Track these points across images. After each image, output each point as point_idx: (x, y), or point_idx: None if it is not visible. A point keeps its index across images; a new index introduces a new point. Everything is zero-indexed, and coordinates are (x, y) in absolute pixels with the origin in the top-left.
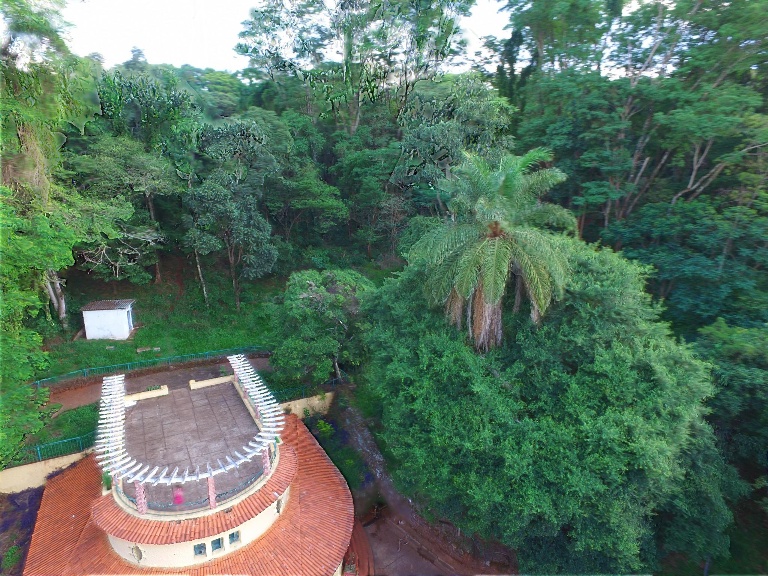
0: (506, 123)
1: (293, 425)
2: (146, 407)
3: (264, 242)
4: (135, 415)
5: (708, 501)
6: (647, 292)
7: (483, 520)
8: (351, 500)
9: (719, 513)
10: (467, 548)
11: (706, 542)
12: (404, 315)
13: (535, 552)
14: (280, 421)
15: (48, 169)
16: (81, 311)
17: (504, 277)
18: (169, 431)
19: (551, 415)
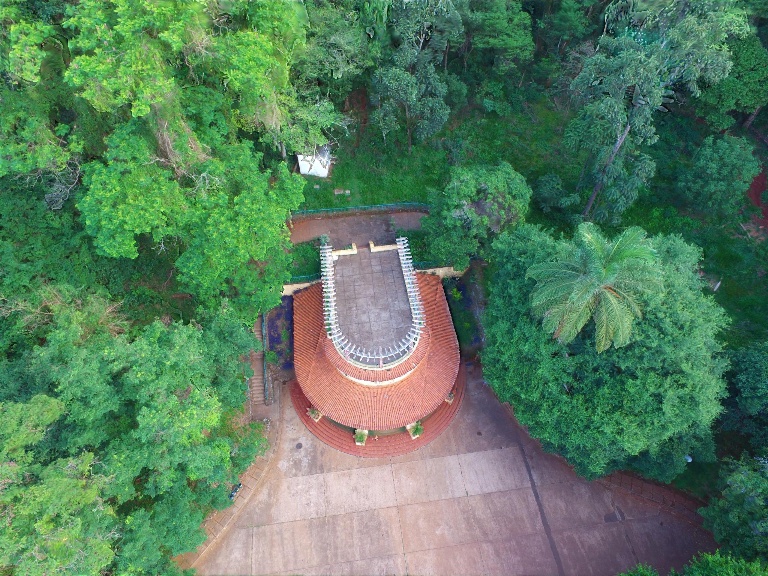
0: (731, 49)
1: (435, 288)
2: (344, 264)
3: (438, 108)
4: (338, 271)
5: (672, 459)
6: (718, 334)
7: None
8: (458, 363)
9: (674, 467)
10: None
11: (658, 473)
12: (515, 295)
13: None
14: (427, 284)
15: None
16: None
17: (578, 331)
18: (358, 293)
19: (585, 394)
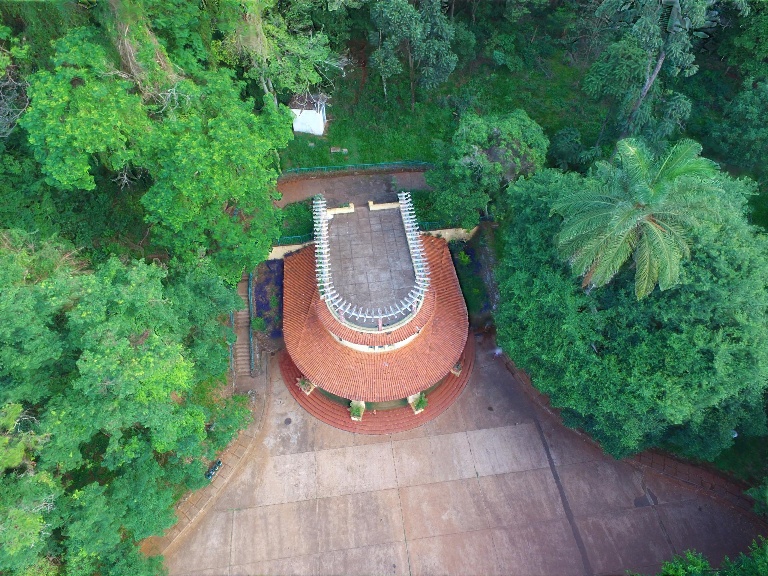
0: None
1: (440, 251)
2: (340, 223)
3: (444, 53)
4: (333, 230)
5: (717, 432)
6: None
7: None
8: (467, 329)
9: (720, 441)
10: None
11: (699, 449)
12: (536, 241)
13: None
14: (431, 246)
15: (262, 11)
16: None
17: (615, 271)
18: (355, 253)
19: (618, 353)
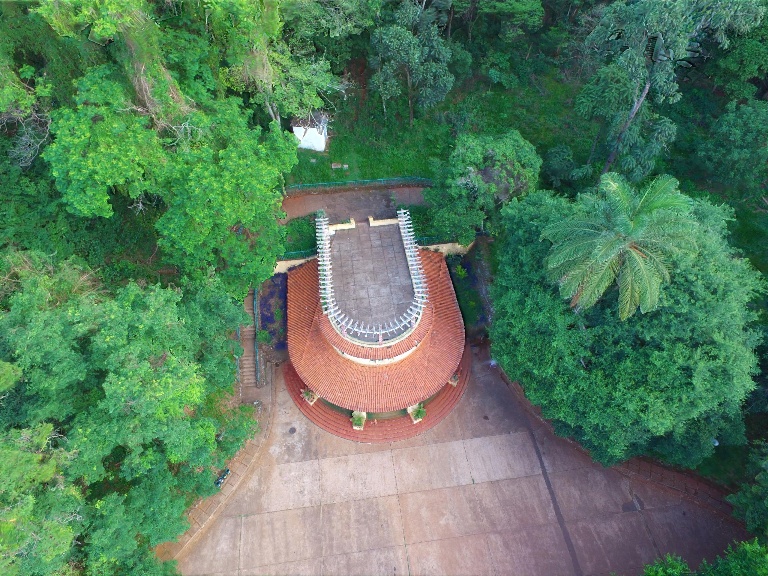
0: None
1: (438, 265)
2: (341, 239)
3: (442, 75)
4: (335, 246)
5: (698, 442)
6: (753, 301)
7: None
8: None
9: (701, 450)
10: None
11: (682, 457)
12: (527, 262)
13: None
14: (429, 261)
15: (267, 40)
16: (291, 126)
17: (599, 295)
18: (356, 268)
19: (605, 369)
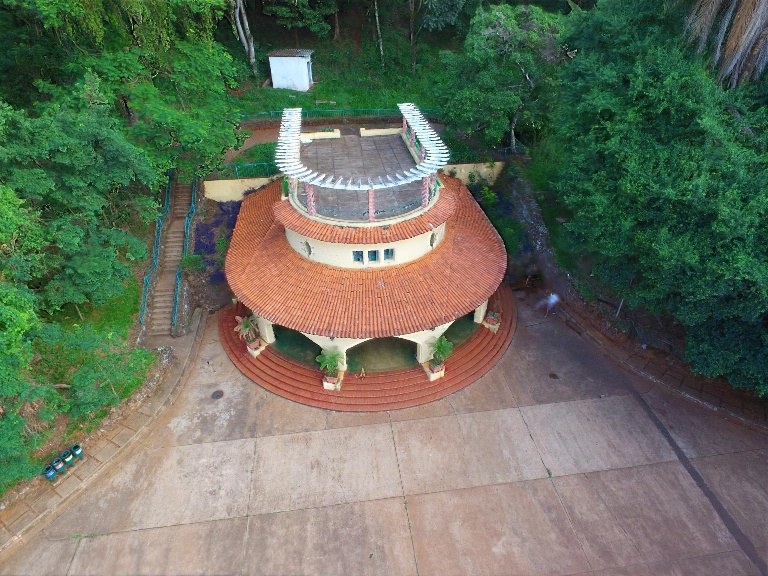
0: None
1: (456, 187)
2: (320, 145)
3: None
4: (311, 149)
5: None
6: None
7: (660, 285)
8: (505, 256)
9: None
10: (623, 328)
11: None
12: (621, 30)
13: (713, 338)
14: (443, 181)
15: None
16: (267, 56)
17: None
18: (339, 165)
19: None
